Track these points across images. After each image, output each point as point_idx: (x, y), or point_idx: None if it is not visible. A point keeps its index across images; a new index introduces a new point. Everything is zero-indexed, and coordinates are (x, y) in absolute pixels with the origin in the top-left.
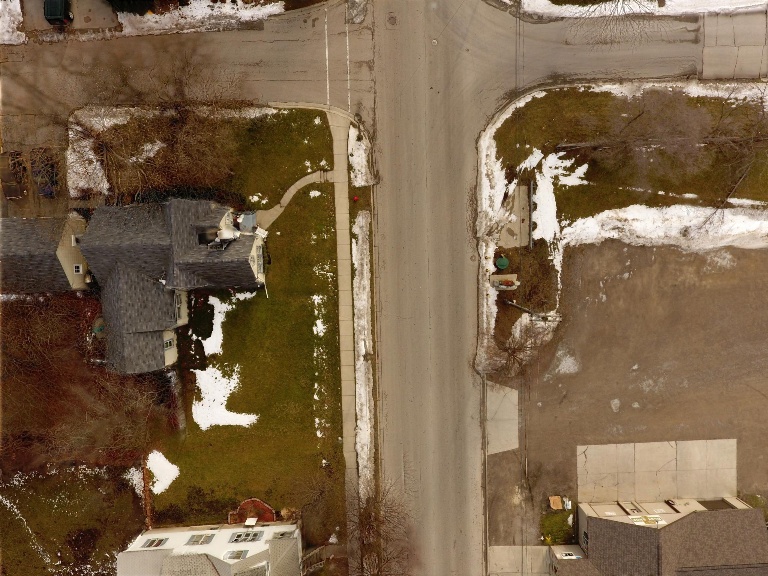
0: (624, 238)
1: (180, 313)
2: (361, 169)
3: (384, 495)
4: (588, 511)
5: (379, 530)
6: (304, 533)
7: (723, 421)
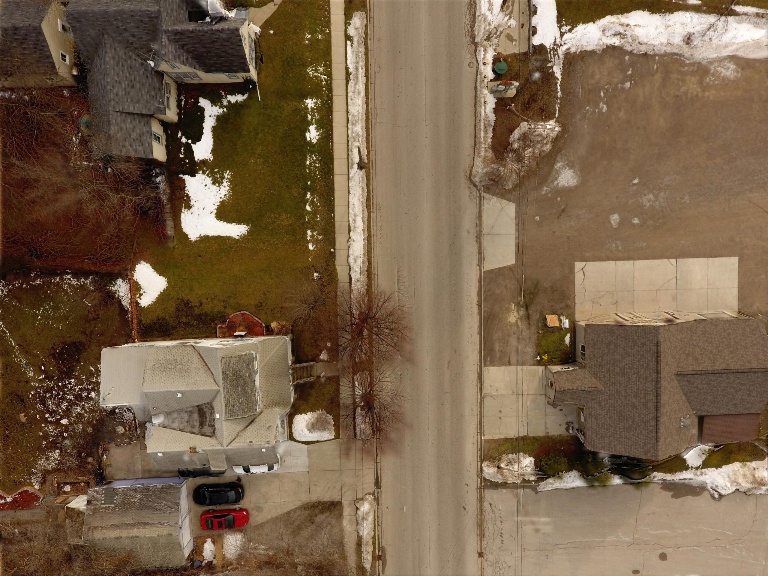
0: (626, 45)
1: (169, 104)
2: None
3: (377, 310)
4: (586, 322)
5: (371, 348)
6: (294, 344)
7: (725, 238)
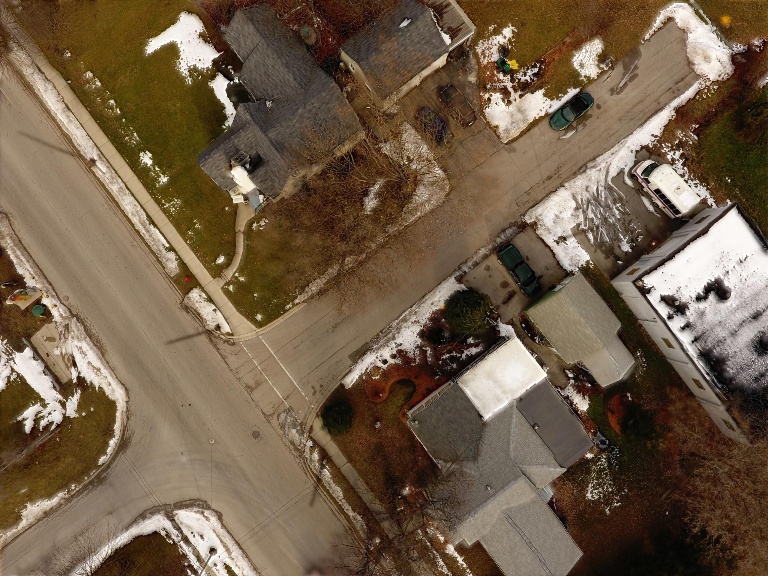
0: None
1: None
2: (200, 304)
3: (3, 61)
4: None
5: None
6: None
7: None
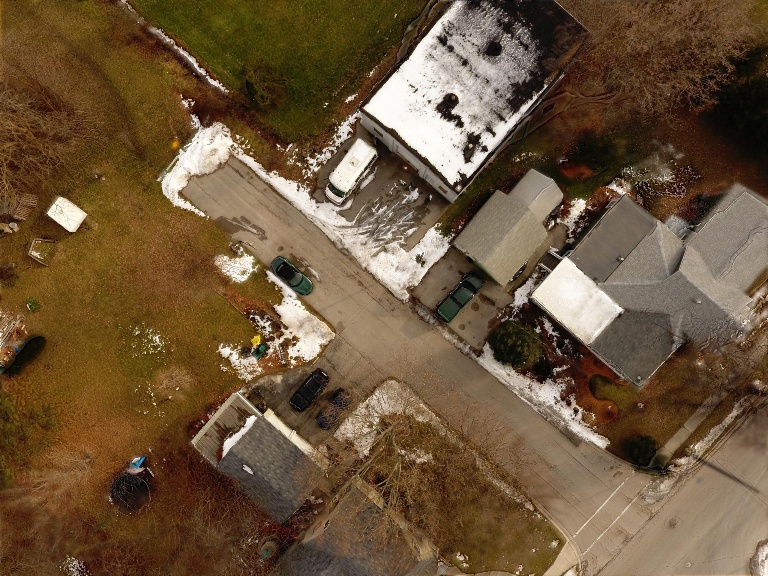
0: None
1: None
2: None
3: None
4: None
5: None
6: None
7: None
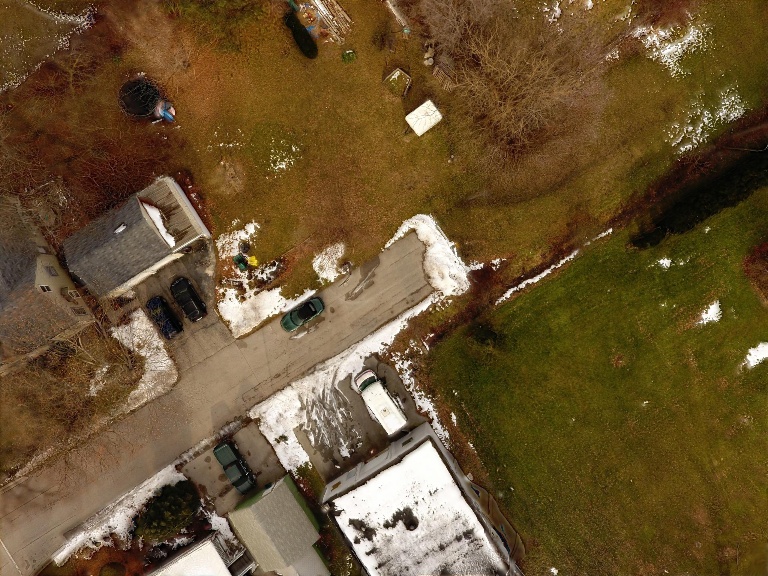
0: None
1: None
2: None
3: None
4: None
5: None
6: None
7: None
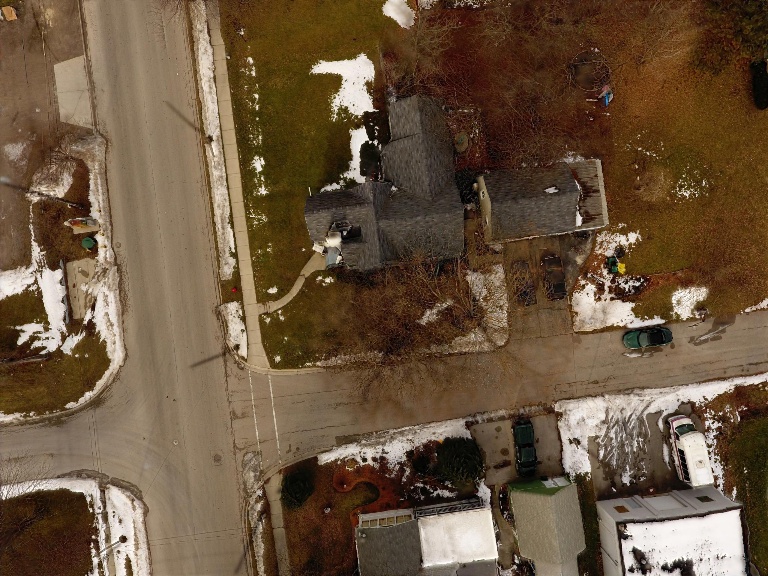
0: None
1: None
2: (233, 318)
3: (180, 5)
4: None
5: None
6: None
7: None
